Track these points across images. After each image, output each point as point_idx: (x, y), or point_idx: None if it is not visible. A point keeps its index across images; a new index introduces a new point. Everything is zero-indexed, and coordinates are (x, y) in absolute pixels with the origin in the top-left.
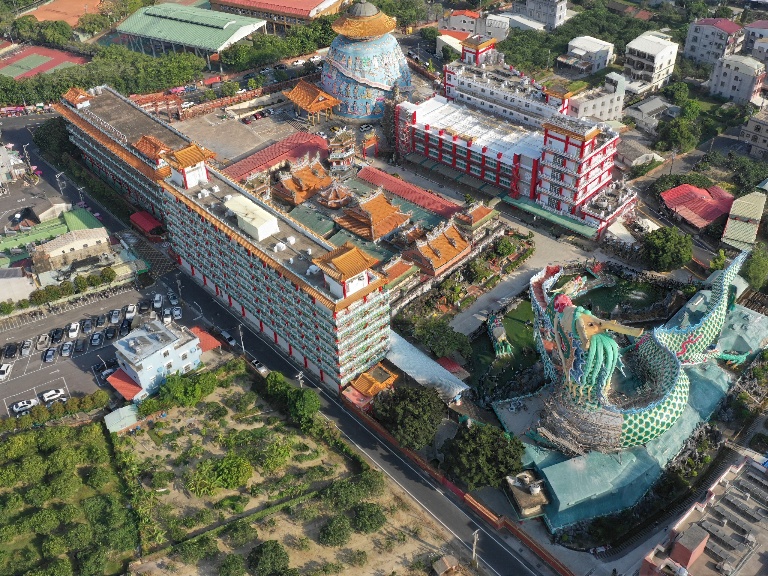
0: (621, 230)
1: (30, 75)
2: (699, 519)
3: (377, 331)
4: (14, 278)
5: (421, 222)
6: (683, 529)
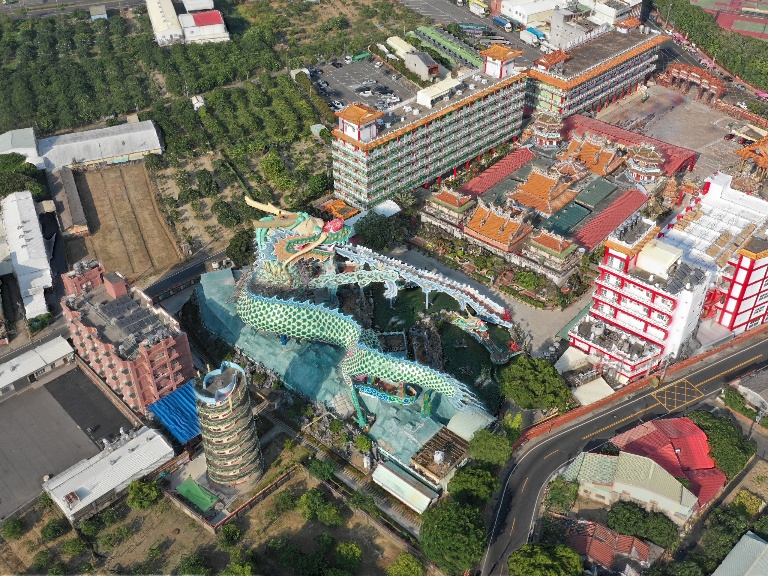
0: (574, 359)
1: (755, 35)
2: (143, 304)
3: (364, 186)
4: (425, 64)
5: (548, 223)
6: (137, 295)
